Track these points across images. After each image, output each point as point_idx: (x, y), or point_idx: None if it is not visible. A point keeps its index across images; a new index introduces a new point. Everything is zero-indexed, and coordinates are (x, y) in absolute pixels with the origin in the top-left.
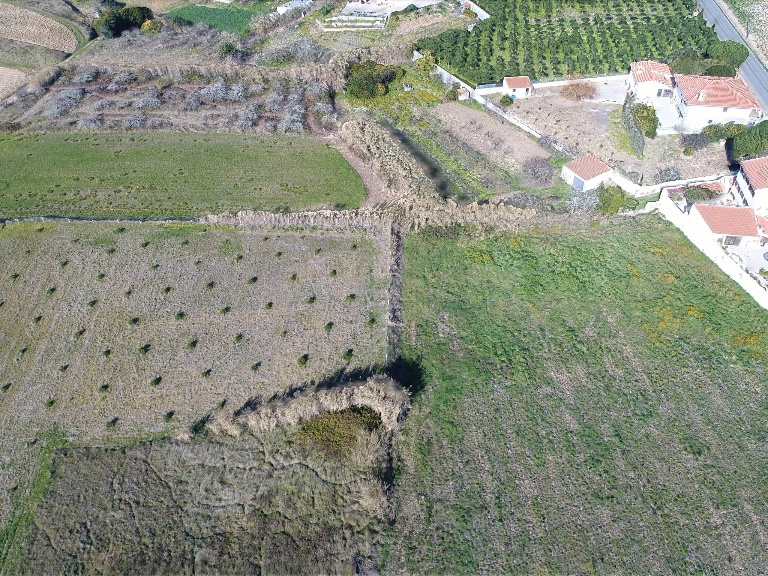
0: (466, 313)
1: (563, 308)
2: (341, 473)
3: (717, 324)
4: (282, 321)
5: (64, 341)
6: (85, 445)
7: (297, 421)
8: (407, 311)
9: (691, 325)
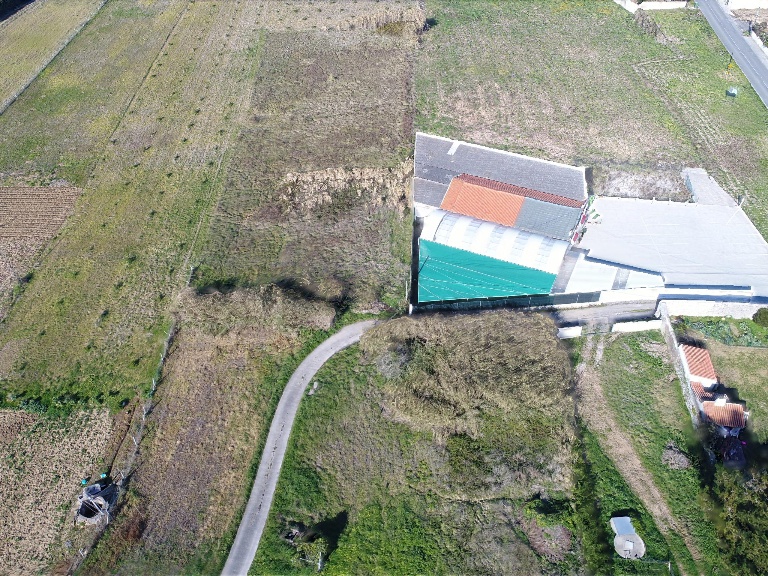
0: (459, 7)
1: (511, 5)
2: (398, 39)
3: (591, 7)
4: (363, 6)
5: (255, 8)
6: (278, 32)
7: (376, 24)
8: (428, 7)
9: (577, 8)
